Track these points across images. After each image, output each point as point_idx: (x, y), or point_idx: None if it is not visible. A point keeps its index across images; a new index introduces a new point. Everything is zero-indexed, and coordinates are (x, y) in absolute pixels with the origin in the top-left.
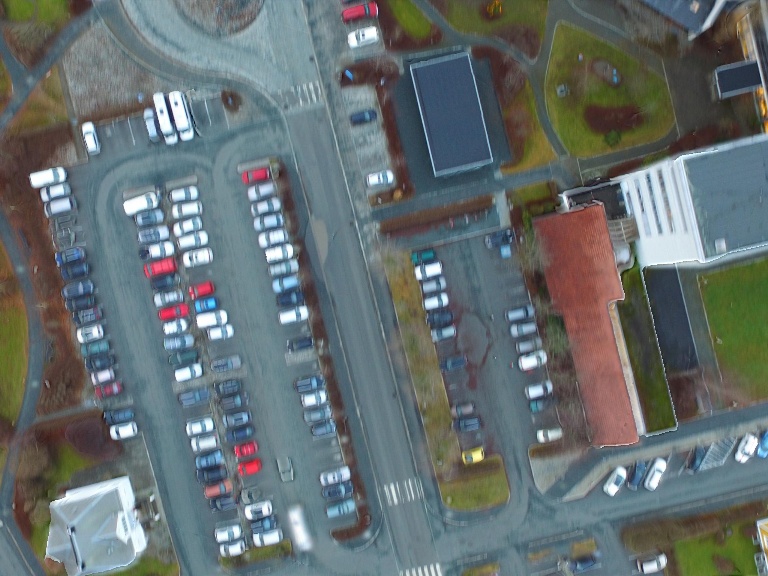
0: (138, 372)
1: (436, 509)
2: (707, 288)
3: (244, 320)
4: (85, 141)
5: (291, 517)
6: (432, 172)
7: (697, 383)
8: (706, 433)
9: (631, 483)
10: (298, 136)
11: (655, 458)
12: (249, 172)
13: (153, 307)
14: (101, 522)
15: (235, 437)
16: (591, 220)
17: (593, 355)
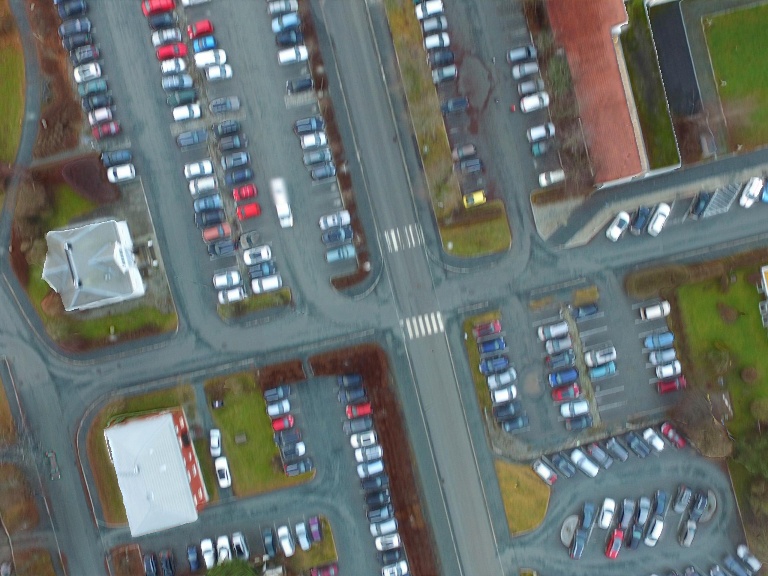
0: (136, 114)
1: (437, 256)
2: (711, 31)
3: (243, 62)
4: None
5: (290, 264)
6: None
7: (701, 125)
8: (710, 179)
9: (634, 226)
10: None
11: (658, 203)
12: None
13: (151, 47)
14: (98, 248)
15: (234, 179)
16: None
17: (596, 87)
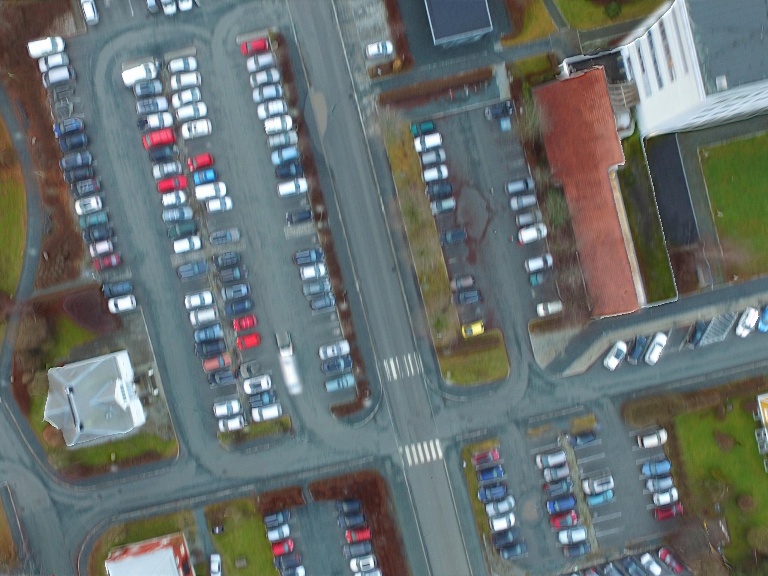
0: (137, 245)
1: (436, 384)
2: (708, 162)
3: (243, 193)
4: (83, 10)
5: (290, 392)
6: (432, 40)
7: (698, 256)
8: (707, 308)
9: (631, 356)
10: (297, 7)
11: (655, 332)
12: (248, 42)
13: (152, 179)
14: (99, 387)
15: (234, 310)
16: (591, 84)
17: (593, 223)
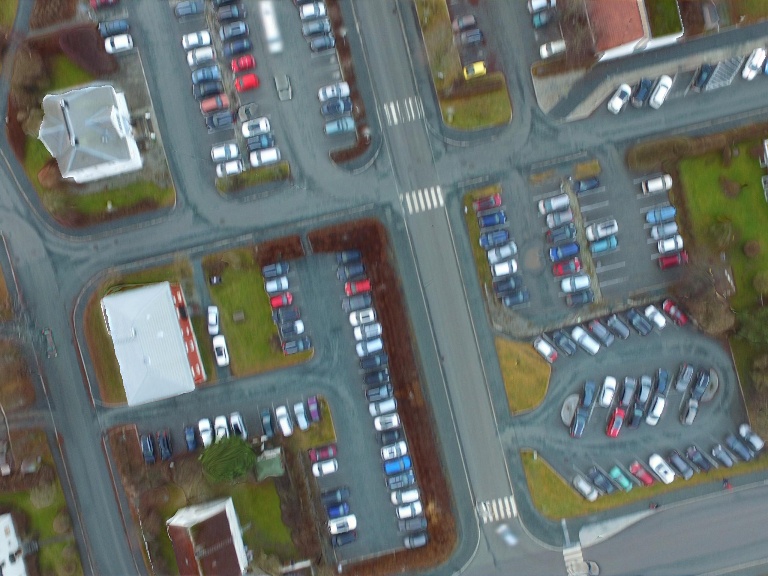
0: None
1: (437, 129)
2: None
3: None
4: None
5: (289, 138)
6: None
7: None
8: (713, 51)
9: (636, 97)
10: None
11: (660, 75)
12: None
13: None
14: (95, 110)
15: (232, 50)
16: None
17: None
